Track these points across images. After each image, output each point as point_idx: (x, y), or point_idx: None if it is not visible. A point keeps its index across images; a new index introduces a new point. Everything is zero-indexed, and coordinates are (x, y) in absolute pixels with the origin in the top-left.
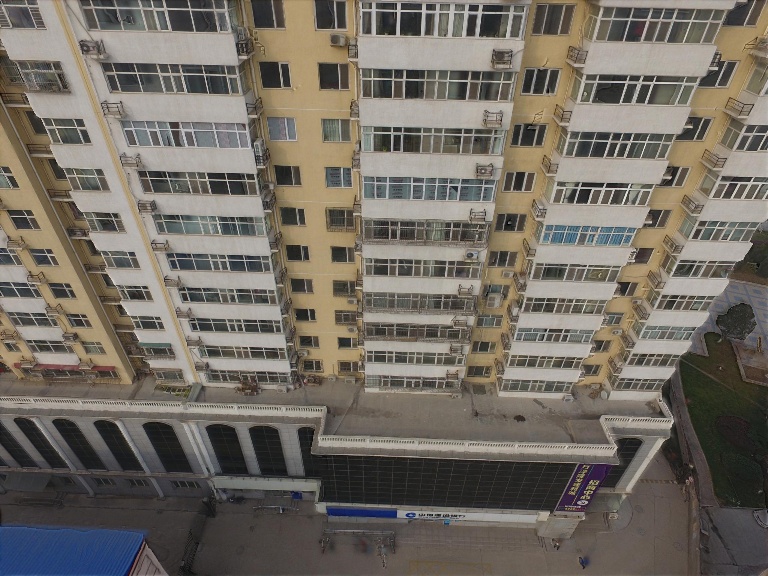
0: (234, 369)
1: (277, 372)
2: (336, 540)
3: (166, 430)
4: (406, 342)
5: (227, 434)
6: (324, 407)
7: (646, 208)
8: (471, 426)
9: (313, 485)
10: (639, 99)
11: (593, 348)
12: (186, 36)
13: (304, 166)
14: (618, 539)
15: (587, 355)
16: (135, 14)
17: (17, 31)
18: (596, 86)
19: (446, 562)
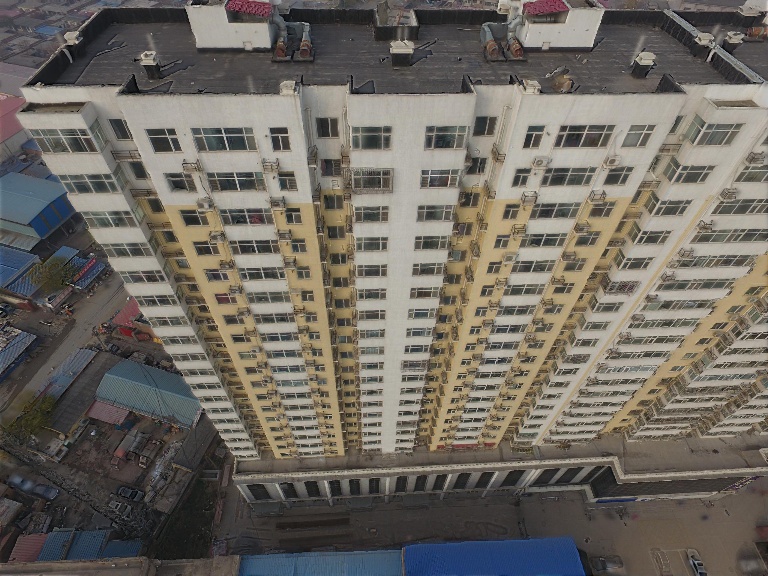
0: (562, 439)
1: None
2: (593, 513)
3: None
4: None
5: None
6: (617, 457)
7: None
8: (693, 459)
9: (585, 487)
10: None
11: None
12: None
13: (664, 367)
14: (743, 498)
15: (760, 421)
16: (640, 339)
17: None
18: None
19: (657, 520)
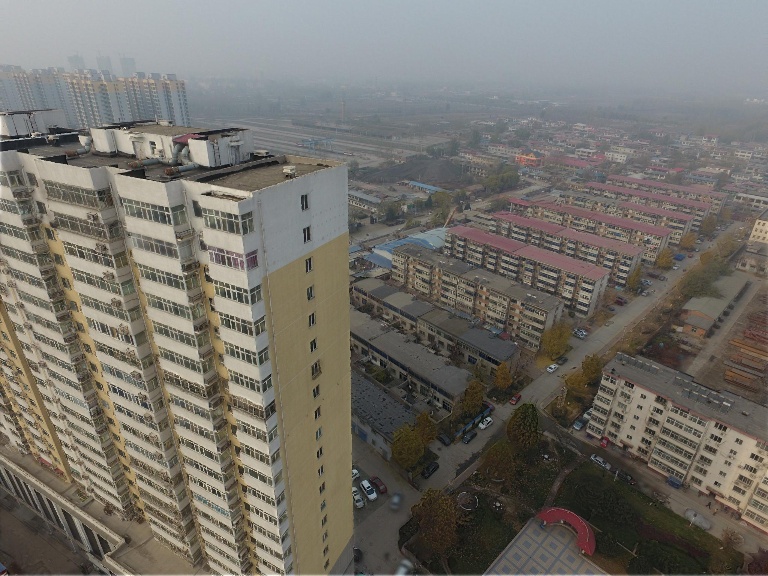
0: (103, 497)
1: (119, 508)
2: None
3: (70, 516)
4: (160, 520)
5: (91, 532)
6: (123, 539)
7: (226, 503)
8: None
9: None
10: (202, 452)
11: (243, 571)
12: (65, 371)
13: (115, 421)
14: None
15: (241, 574)
16: None
17: (27, 352)
18: (185, 440)
19: None
